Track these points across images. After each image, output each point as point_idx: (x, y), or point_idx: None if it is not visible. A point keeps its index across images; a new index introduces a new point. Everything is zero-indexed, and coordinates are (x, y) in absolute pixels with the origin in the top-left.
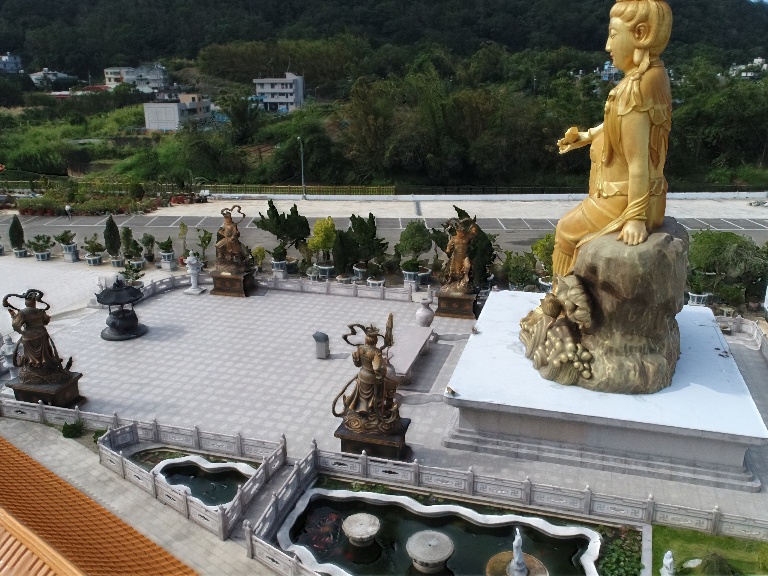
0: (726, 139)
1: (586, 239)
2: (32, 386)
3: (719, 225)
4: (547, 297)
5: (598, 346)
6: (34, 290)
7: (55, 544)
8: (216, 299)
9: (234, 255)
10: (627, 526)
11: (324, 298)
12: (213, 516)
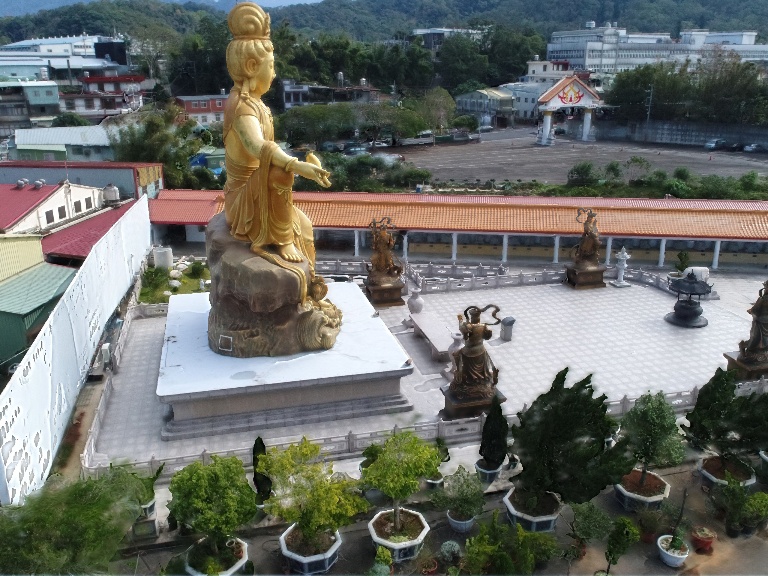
0: None
1: None
2: None
3: None
4: None
5: None
6: (581, 208)
7: (396, 207)
8: None
9: None
10: None
11: None
12: None
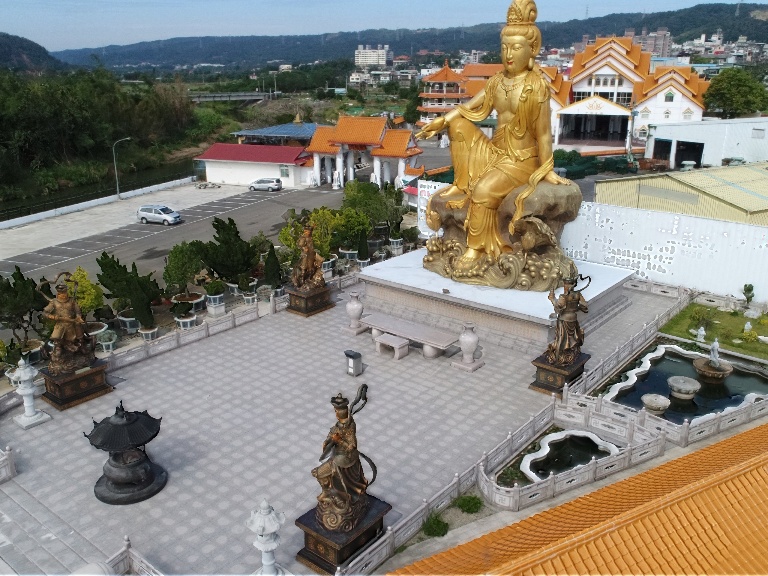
0: (34, 141)
1: (528, 191)
2: (367, 521)
3: (229, 205)
4: (530, 236)
5: (556, 258)
6: (364, 386)
7: None
8: (90, 409)
9: (78, 342)
10: (656, 338)
11: (188, 351)
12: (655, 443)
